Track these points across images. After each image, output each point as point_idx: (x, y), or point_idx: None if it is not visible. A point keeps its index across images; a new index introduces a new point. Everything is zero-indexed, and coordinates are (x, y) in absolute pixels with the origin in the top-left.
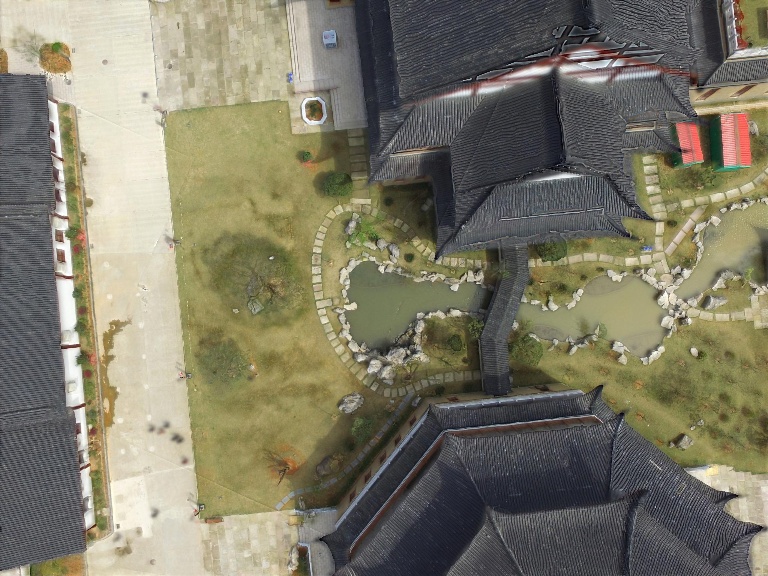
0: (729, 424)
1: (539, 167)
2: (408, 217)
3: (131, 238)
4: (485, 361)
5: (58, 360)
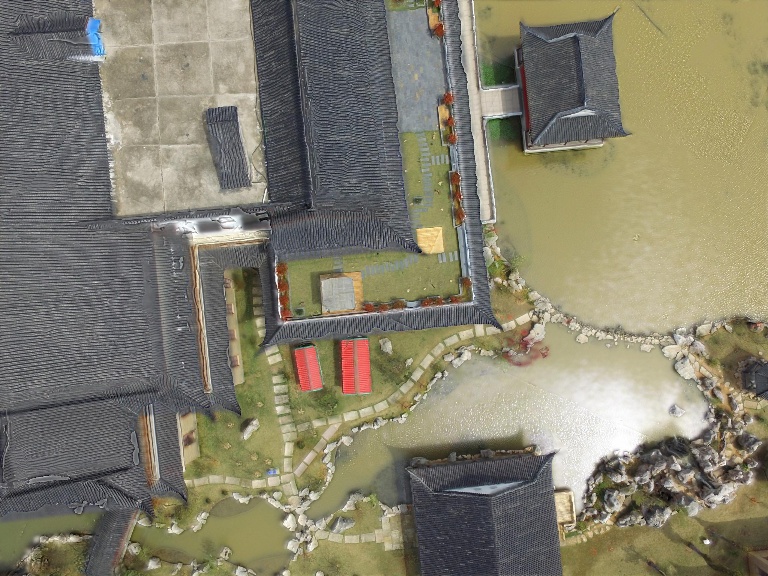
0: None
1: (7, 484)
2: None
3: None
4: None
5: None
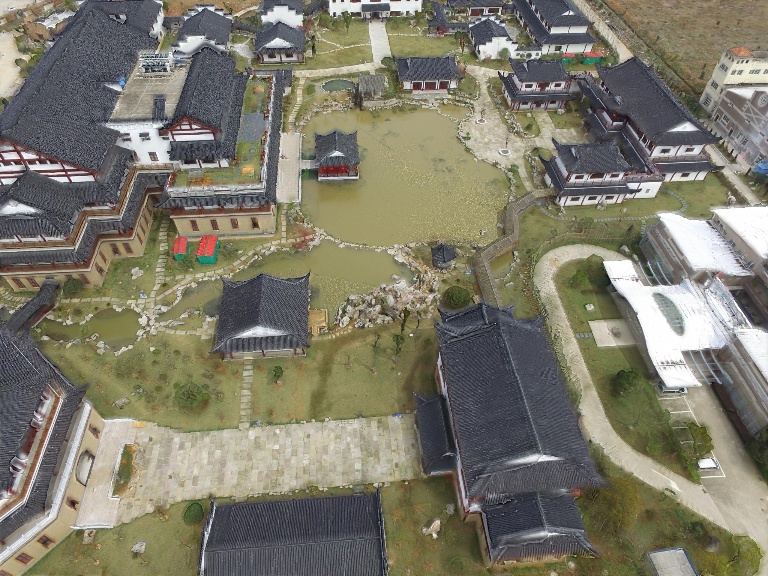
0: (162, 393)
1: None
2: None
3: None
4: None
5: None
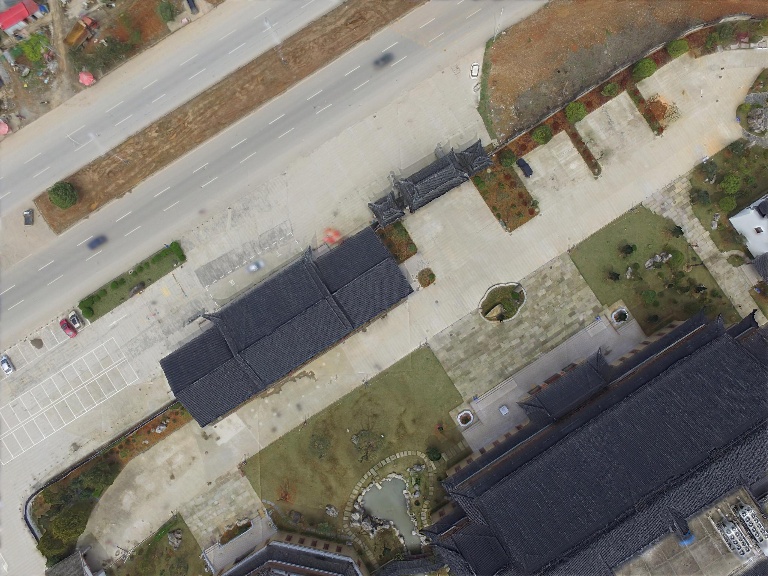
0: None
1: (475, 571)
2: (437, 492)
3: (357, 359)
4: (385, 570)
5: (285, 372)
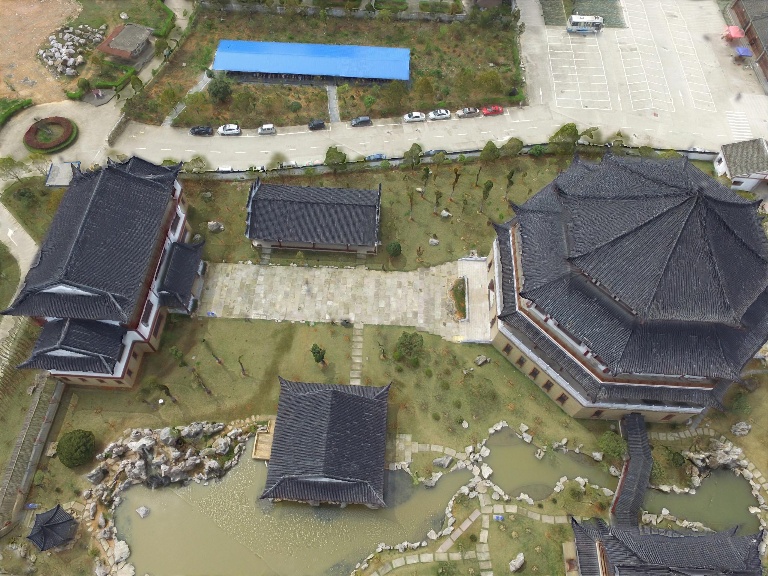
0: (443, 368)
1: None
2: None
3: None
4: (648, 442)
5: None
